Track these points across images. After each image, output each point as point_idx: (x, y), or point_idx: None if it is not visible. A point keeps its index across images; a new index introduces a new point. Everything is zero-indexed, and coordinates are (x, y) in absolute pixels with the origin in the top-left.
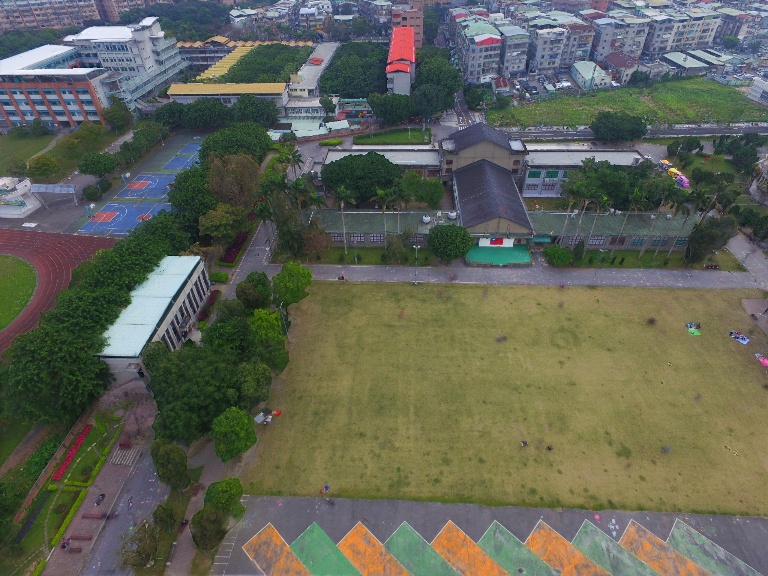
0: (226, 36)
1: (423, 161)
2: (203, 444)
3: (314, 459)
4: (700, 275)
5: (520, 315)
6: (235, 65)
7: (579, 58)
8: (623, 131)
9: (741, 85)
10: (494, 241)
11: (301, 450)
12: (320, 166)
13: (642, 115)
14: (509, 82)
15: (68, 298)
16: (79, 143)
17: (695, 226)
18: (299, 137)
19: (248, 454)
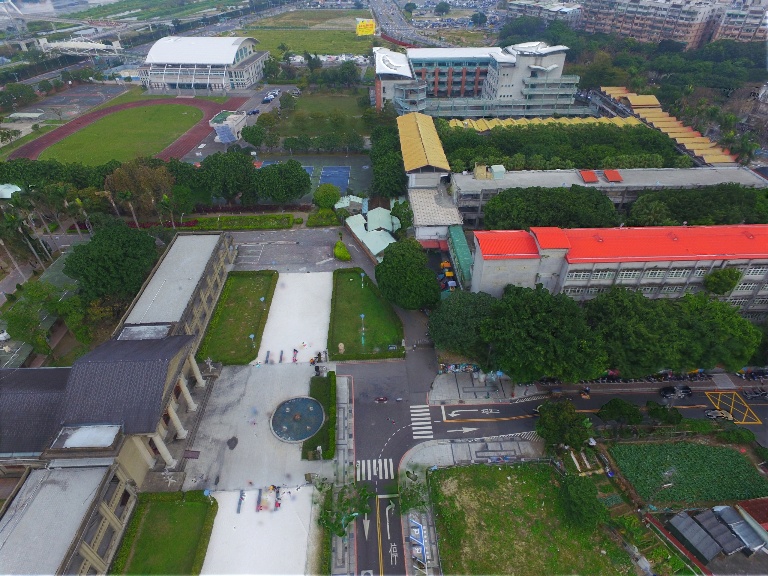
0: None
1: (145, 317)
2: None
3: None
4: None
5: None
6: (509, 126)
7: None
8: None
9: None
10: None
11: None
12: None
13: None
14: None
15: None
16: (311, 120)
17: None
18: (347, 222)
19: None
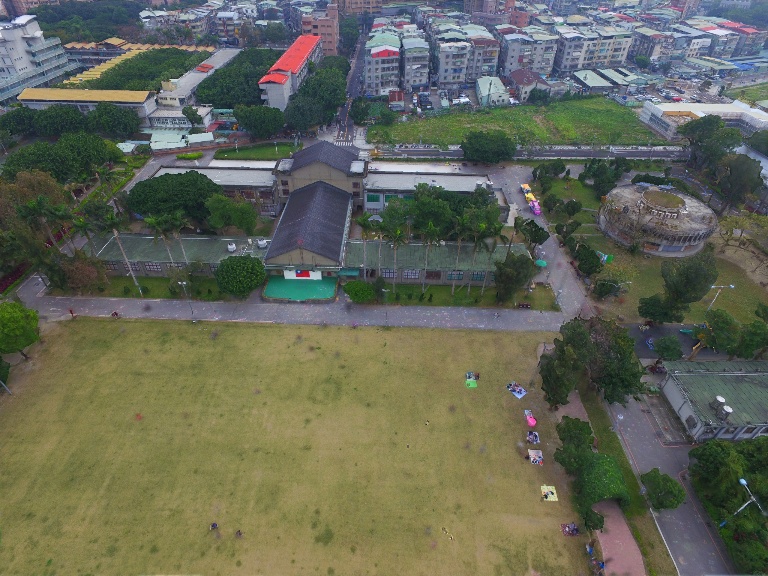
0: (127, 38)
1: (257, 181)
2: None
3: None
4: (508, 315)
5: (291, 361)
6: (110, 69)
7: (485, 73)
8: (488, 153)
9: (638, 106)
10: (300, 273)
11: None
12: None
13: (519, 135)
14: (410, 96)
15: None
16: None
17: (494, 264)
18: (155, 149)
19: None
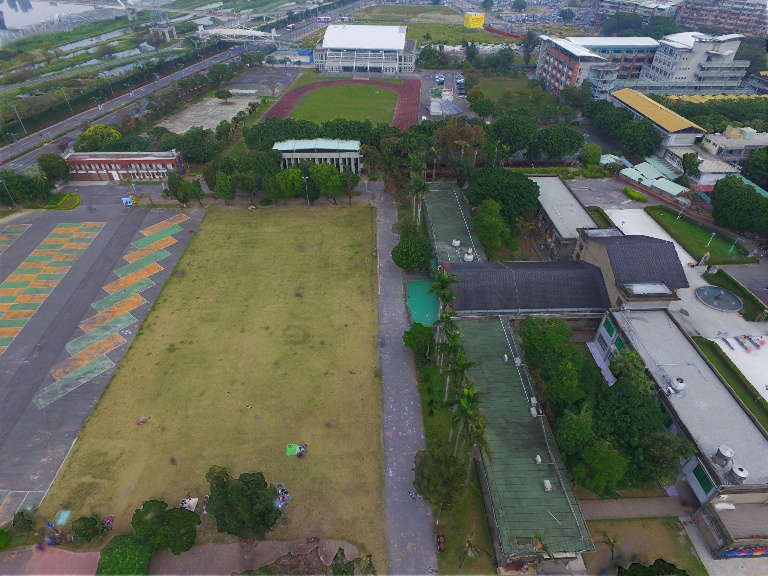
0: None
1: (570, 228)
2: (240, 195)
3: (219, 225)
4: (419, 514)
5: (330, 310)
6: (722, 99)
7: None
8: None
9: None
10: None
11: (226, 221)
12: None
13: None
14: None
15: (302, 120)
16: (516, 97)
17: None
18: (622, 173)
19: (230, 207)
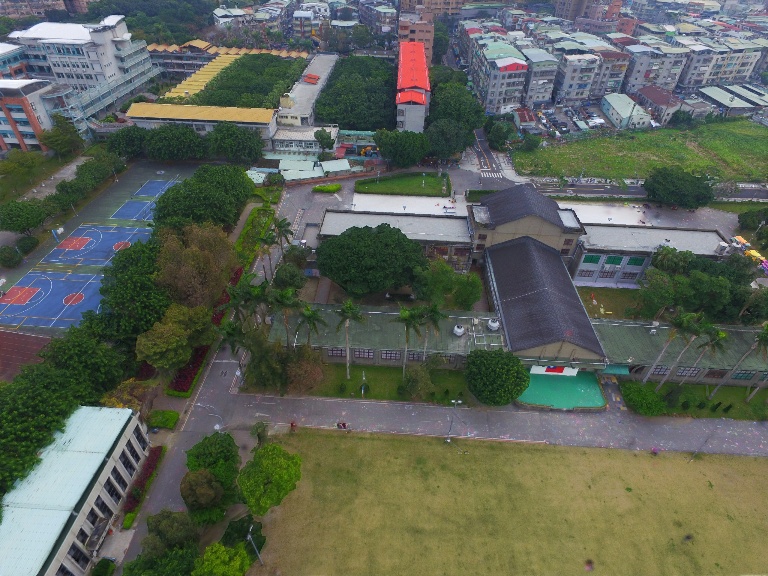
0: (207, 39)
1: (449, 234)
2: None
3: None
4: None
5: (606, 513)
6: (214, 80)
7: (610, 89)
8: (687, 196)
9: None
10: (552, 368)
11: None
12: (314, 229)
13: (701, 172)
14: None
15: None
16: (3, 179)
17: None
18: (288, 180)
19: None
